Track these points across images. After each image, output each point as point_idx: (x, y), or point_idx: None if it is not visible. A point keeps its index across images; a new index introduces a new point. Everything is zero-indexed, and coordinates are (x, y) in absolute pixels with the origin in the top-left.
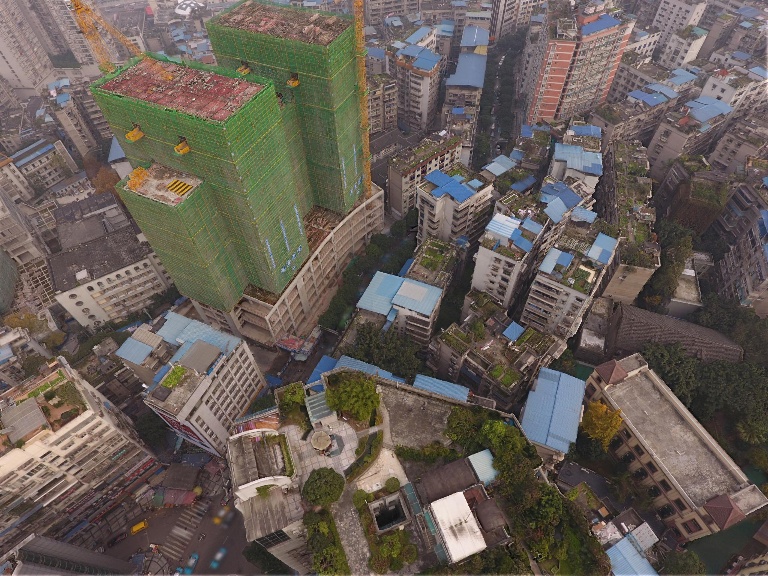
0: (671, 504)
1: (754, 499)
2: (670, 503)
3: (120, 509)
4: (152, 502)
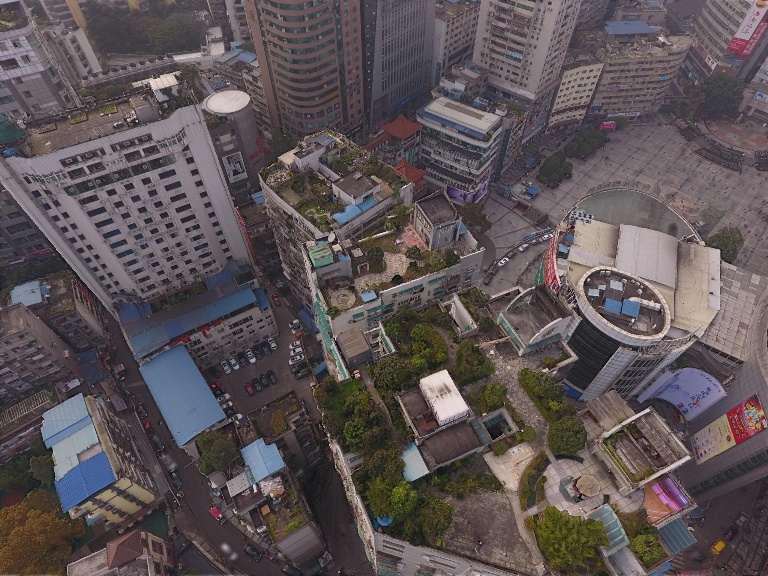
0: (164, 573)
1: (81, 568)
2: (164, 575)
3: (755, 568)
4: (725, 575)
